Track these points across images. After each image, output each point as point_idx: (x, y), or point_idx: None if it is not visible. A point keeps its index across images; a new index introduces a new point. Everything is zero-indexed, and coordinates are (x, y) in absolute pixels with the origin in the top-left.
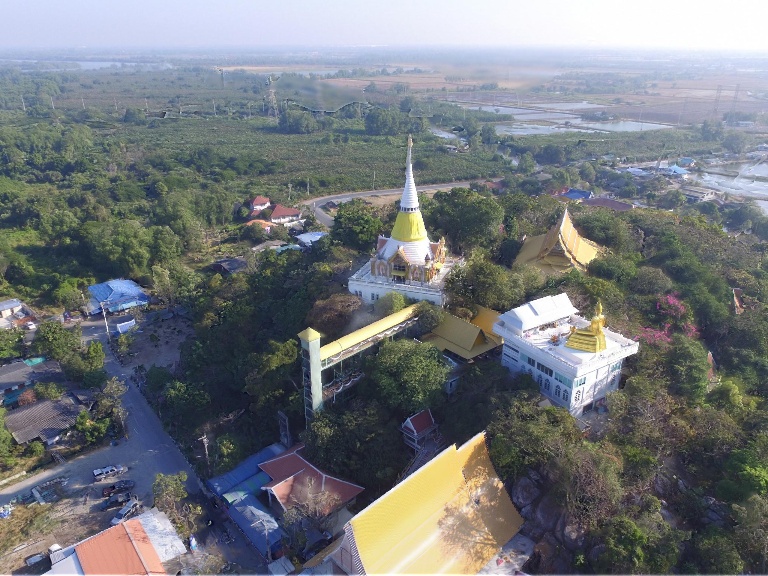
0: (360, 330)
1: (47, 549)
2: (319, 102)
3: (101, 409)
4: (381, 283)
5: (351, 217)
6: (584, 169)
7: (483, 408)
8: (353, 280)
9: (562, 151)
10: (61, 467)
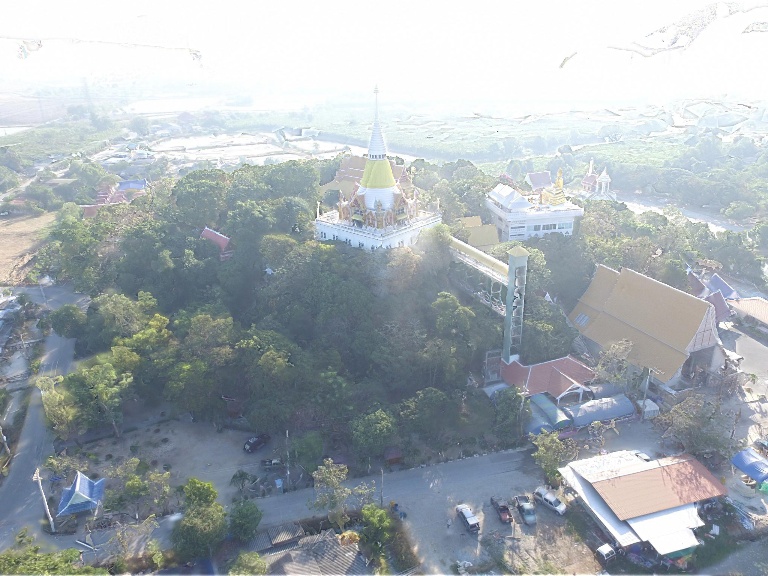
0: (481, 252)
1: (591, 570)
2: (118, 77)
3: (342, 510)
4: (405, 228)
5: (156, 226)
6: (77, 167)
7: (568, 259)
8: (385, 236)
9: (17, 158)
10: (431, 570)
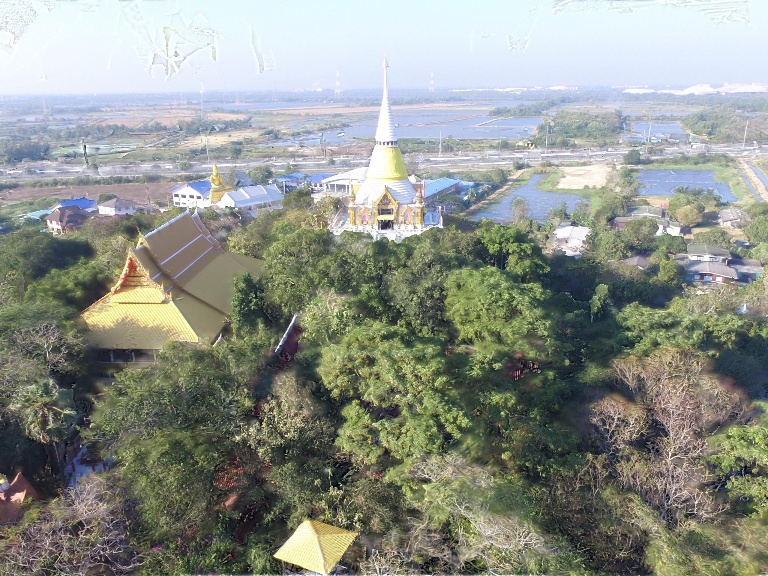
0: None
1: None
2: None
3: None
4: None
5: None
6: None
7: None
8: None
9: None
10: None
